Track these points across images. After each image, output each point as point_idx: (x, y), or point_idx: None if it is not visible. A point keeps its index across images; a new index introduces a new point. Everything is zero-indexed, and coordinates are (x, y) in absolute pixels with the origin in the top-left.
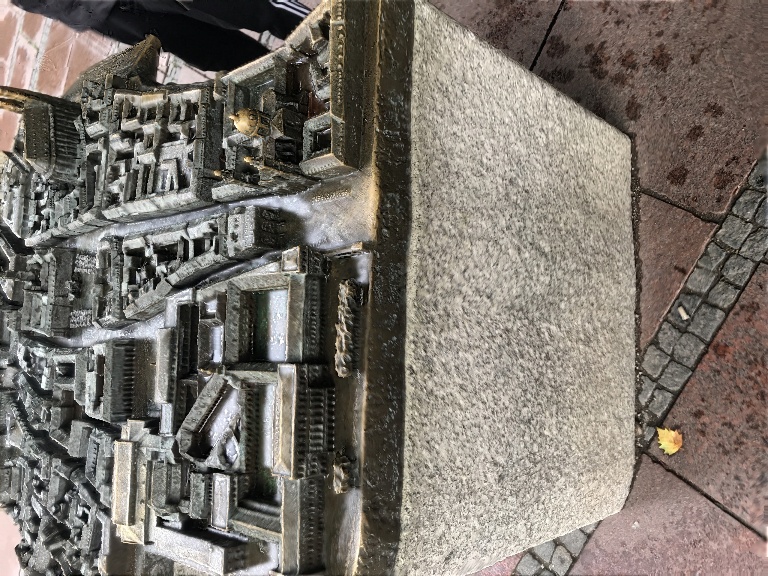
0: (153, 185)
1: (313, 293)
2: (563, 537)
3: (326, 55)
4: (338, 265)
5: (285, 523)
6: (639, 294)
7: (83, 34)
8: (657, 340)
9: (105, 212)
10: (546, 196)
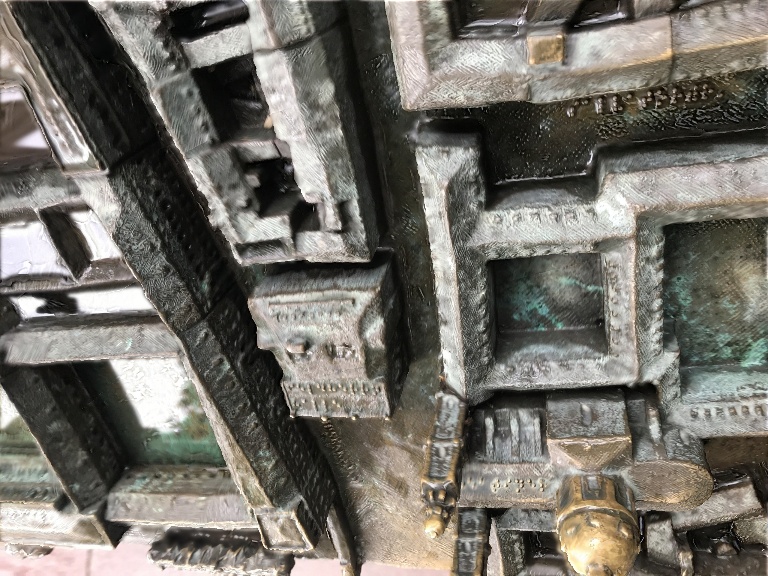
0: None
1: None
2: None
3: (763, 536)
4: None
5: None
6: None
7: None
8: None
9: None
10: None
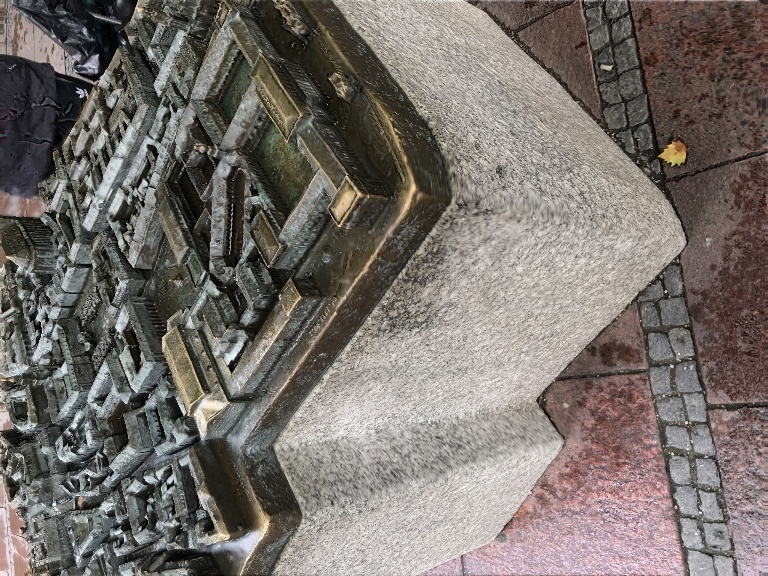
0: (112, 151)
1: (253, 27)
2: (665, 320)
3: None
4: (263, 5)
5: (317, 158)
6: (567, 88)
7: (33, 202)
8: (605, 103)
9: (85, 221)
10: (425, 3)
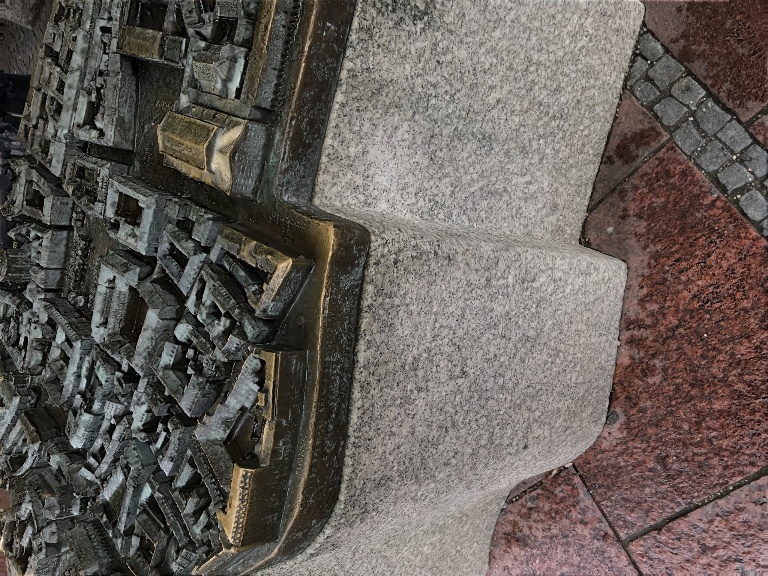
0: None
1: None
2: (662, 84)
3: None
4: None
5: None
6: None
7: None
8: None
9: (53, 163)
10: None
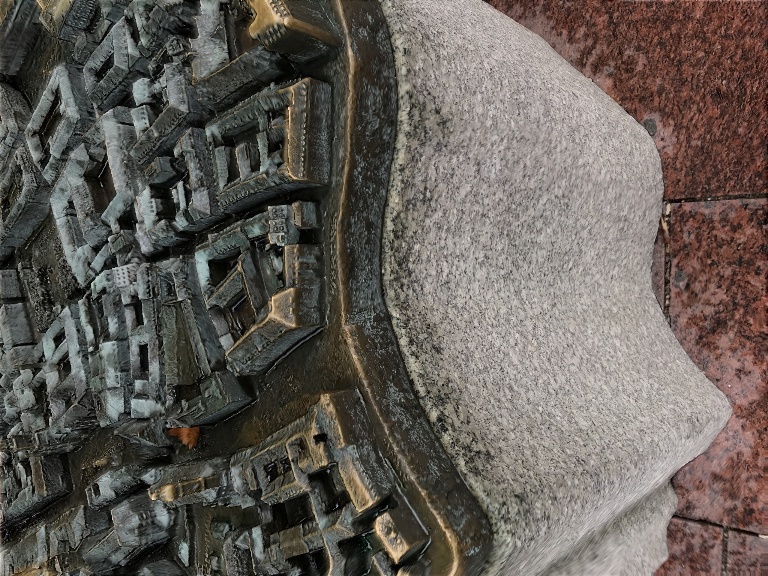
0: None
1: None
2: None
3: None
4: None
5: None
6: None
7: None
8: None
9: None
10: None
